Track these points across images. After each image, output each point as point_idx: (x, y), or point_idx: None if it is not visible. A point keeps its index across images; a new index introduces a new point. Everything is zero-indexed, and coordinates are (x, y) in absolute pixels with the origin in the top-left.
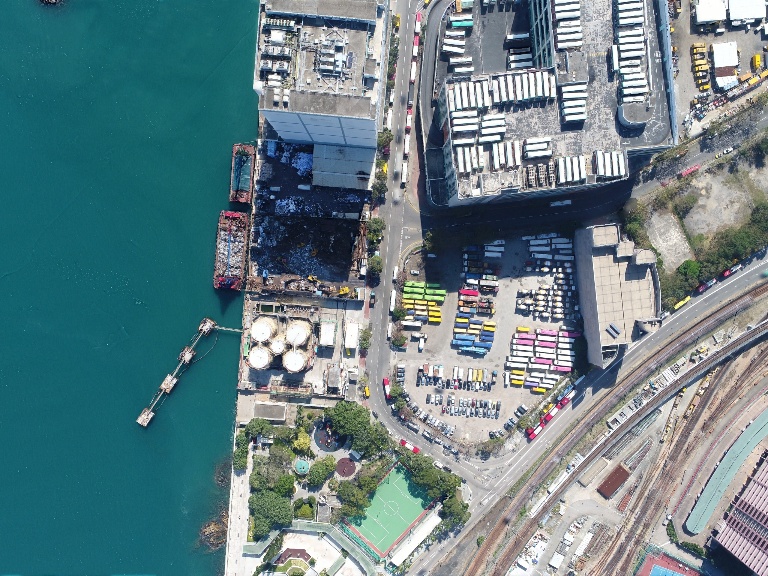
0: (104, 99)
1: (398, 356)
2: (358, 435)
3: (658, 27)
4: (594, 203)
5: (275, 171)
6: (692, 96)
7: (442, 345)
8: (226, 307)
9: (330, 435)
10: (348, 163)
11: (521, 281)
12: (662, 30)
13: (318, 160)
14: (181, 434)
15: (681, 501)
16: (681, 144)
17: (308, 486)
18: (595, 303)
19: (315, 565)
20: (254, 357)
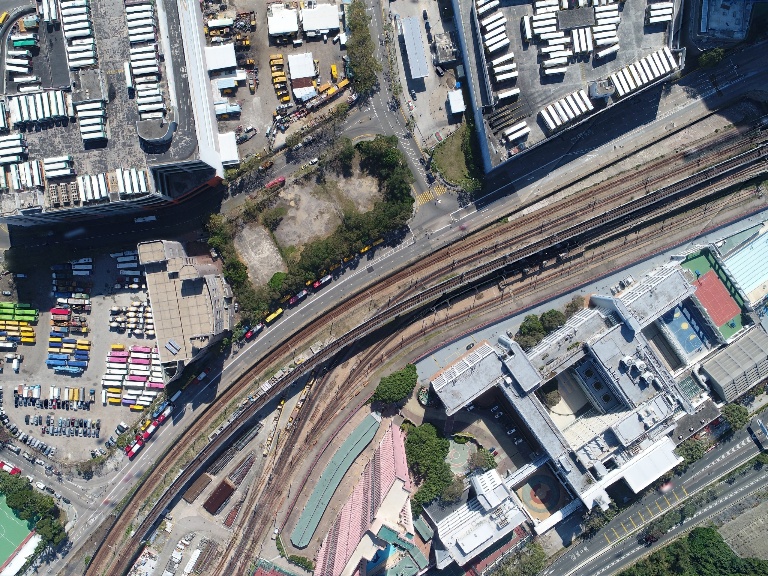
0: None
1: None
2: None
3: None
4: (184, 218)
5: None
6: (274, 108)
7: (39, 365)
8: None
9: None
10: None
11: (114, 298)
12: None
13: None
14: None
15: (288, 514)
16: (264, 156)
17: None
18: (153, 320)
19: None
20: None
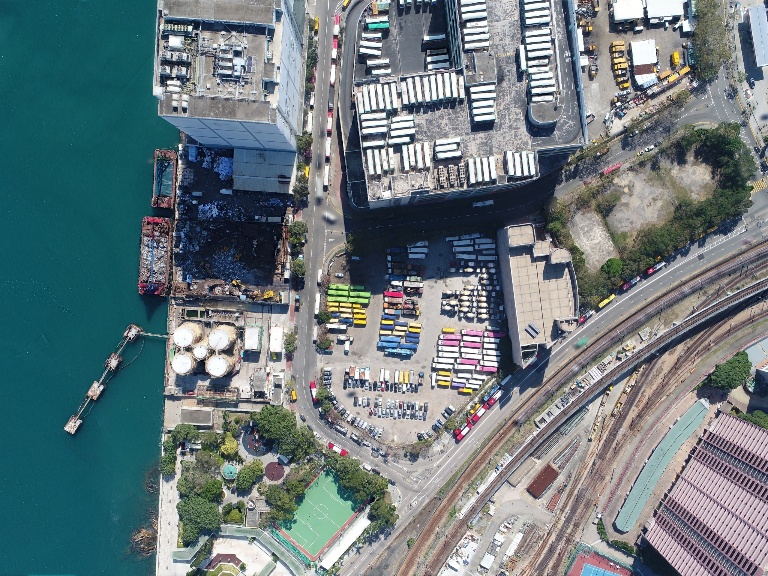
0: (25, 107)
1: (324, 359)
2: (283, 439)
3: (567, 26)
4: (517, 203)
5: (197, 176)
6: (612, 94)
7: (368, 347)
8: (152, 313)
9: (258, 439)
10: (268, 167)
11: (446, 282)
12: (571, 29)
13: (238, 164)
14: (109, 441)
15: (610, 499)
16: (602, 142)
17: (237, 491)
18: (514, 303)
19: (246, 570)
20: (177, 363)
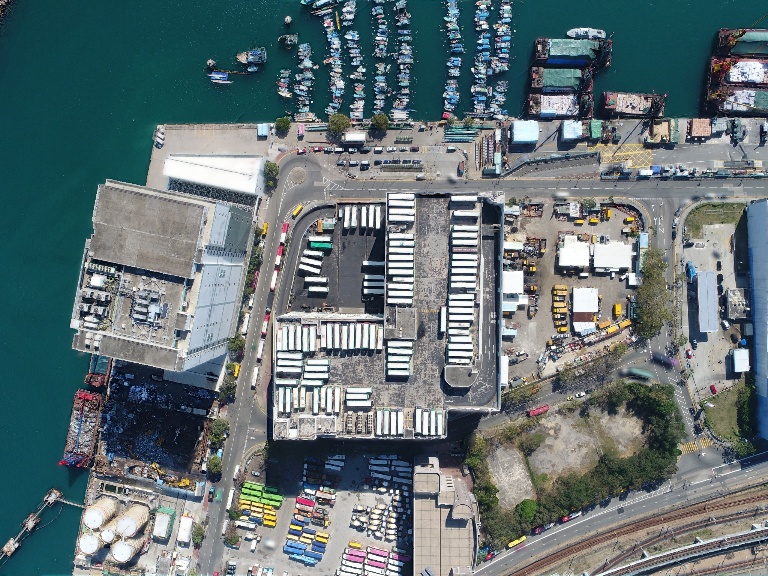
0: None
1: (231, 552)
2: None
3: (497, 288)
4: None
5: None
6: (549, 336)
7: (275, 548)
8: (74, 480)
9: None
10: None
11: (359, 496)
12: (499, 292)
13: None
14: None
15: None
16: (532, 383)
17: None
18: (413, 545)
19: None
20: (84, 542)
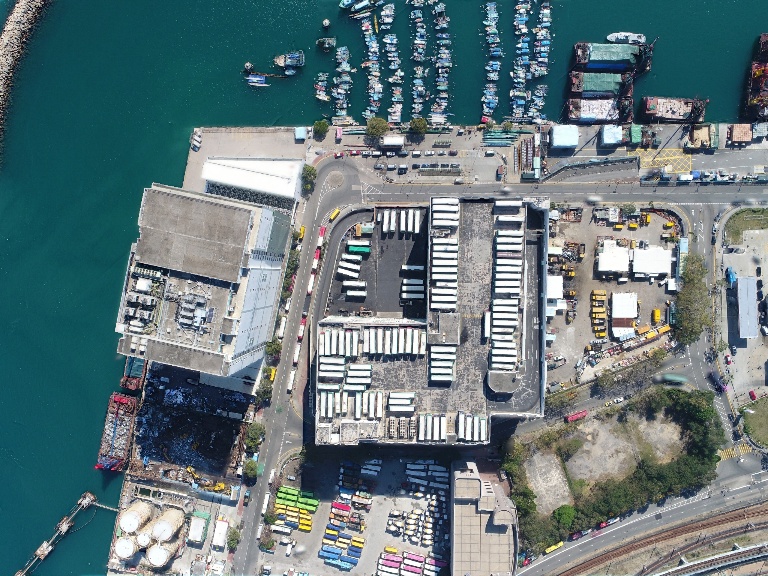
0: (18, 270)
1: (266, 557)
2: None
3: (540, 293)
4: None
5: None
6: (587, 341)
7: (310, 553)
8: (108, 483)
9: None
10: None
11: (395, 501)
12: None
13: None
14: None
15: None
16: (570, 388)
17: None
18: (453, 550)
19: None
20: (120, 546)
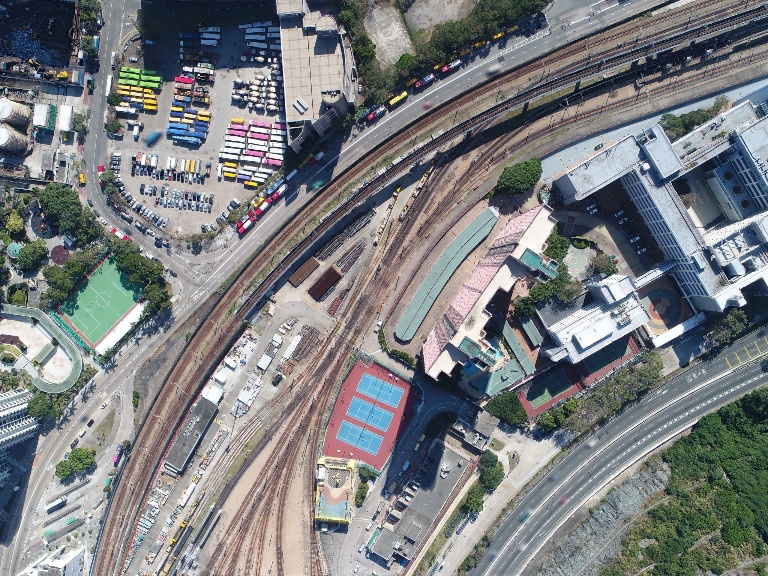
0: None
1: (115, 145)
2: (61, 214)
3: None
4: None
5: None
6: None
7: (158, 135)
8: None
9: (45, 221)
10: None
11: (238, 72)
12: None
13: None
14: None
15: (393, 307)
16: None
17: (23, 272)
18: (283, 77)
19: (27, 353)
20: None
